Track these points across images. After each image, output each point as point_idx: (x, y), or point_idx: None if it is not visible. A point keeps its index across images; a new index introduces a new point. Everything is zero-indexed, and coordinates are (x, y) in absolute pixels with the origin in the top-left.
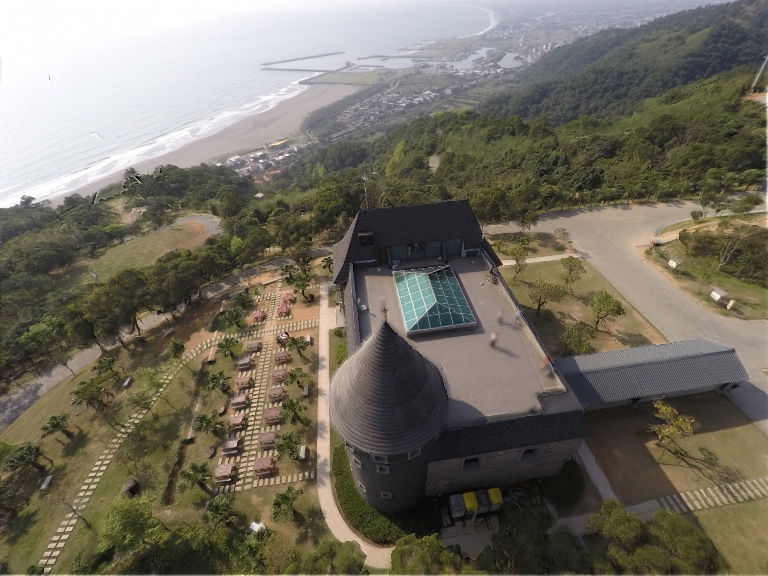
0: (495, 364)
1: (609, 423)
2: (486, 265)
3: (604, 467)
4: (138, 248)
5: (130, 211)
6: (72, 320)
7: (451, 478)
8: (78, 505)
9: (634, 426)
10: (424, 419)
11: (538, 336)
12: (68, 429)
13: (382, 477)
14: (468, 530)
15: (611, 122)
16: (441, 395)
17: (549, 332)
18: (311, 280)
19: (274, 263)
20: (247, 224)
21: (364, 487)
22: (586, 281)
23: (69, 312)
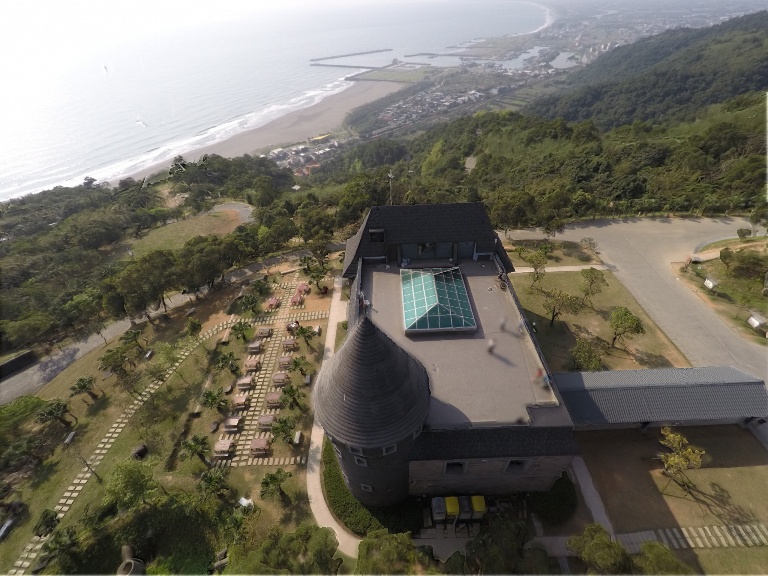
0: (490, 371)
1: (613, 445)
2: (497, 270)
3: (601, 490)
4: (177, 231)
5: (174, 196)
6: (107, 293)
7: (434, 480)
8: (93, 461)
9: (640, 451)
10: (401, 416)
11: (538, 346)
12: (93, 392)
13: (361, 469)
14: (448, 534)
15: (664, 129)
16: (422, 395)
17: (561, 344)
18: (327, 273)
19: (297, 254)
20: (277, 215)
21: (347, 477)
22: (609, 295)
23: (105, 285)
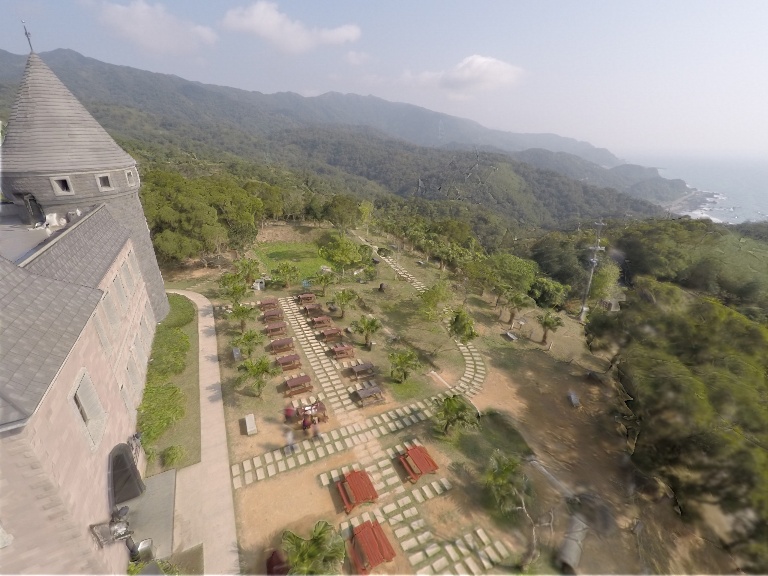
0: None
1: None
2: None
3: None
4: None
5: None
6: None
7: None
8: (418, 284)
9: None
10: None
11: None
12: None
13: None
14: None
15: None
16: None
17: None
18: None
19: None
20: None
21: None
22: None
23: None
